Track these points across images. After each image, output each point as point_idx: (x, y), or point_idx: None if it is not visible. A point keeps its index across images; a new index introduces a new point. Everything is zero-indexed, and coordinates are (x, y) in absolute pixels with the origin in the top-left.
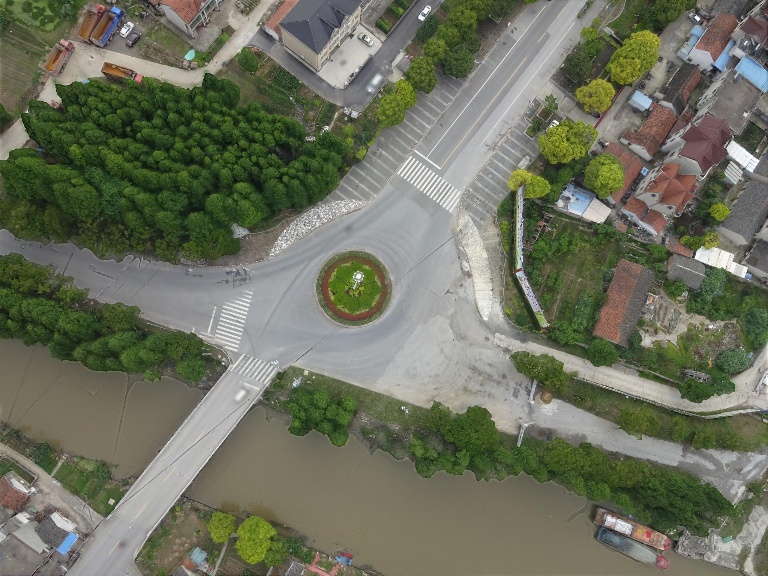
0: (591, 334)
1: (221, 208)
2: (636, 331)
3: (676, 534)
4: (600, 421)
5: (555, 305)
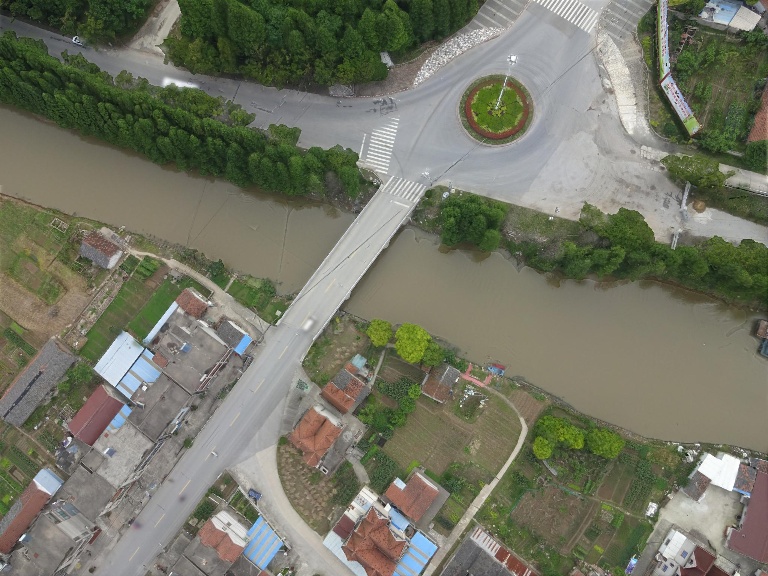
0: (744, 144)
1: (373, 25)
2: None
3: None
4: (759, 228)
5: (704, 116)
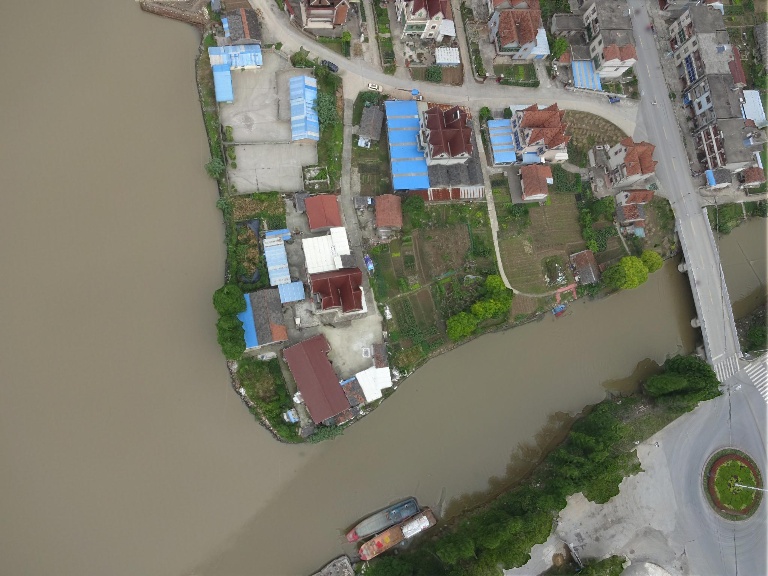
0: None
1: None
2: None
3: (359, 570)
4: None
5: None
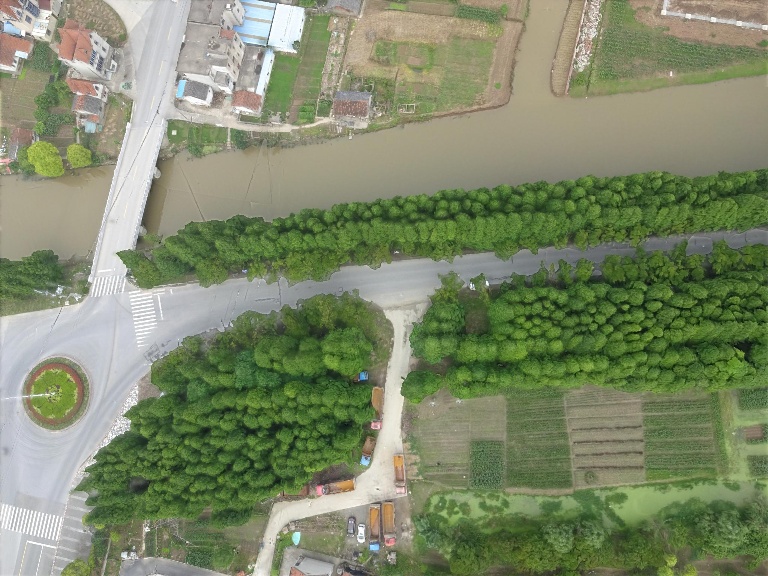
0: None
1: None
2: None
3: None
4: None
5: None
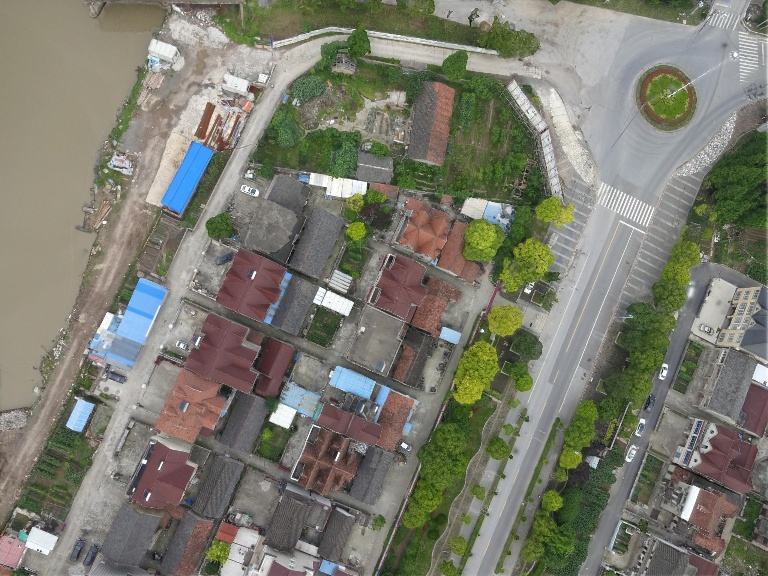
0: None
1: None
2: (417, 98)
3: None
4: None
5: None
